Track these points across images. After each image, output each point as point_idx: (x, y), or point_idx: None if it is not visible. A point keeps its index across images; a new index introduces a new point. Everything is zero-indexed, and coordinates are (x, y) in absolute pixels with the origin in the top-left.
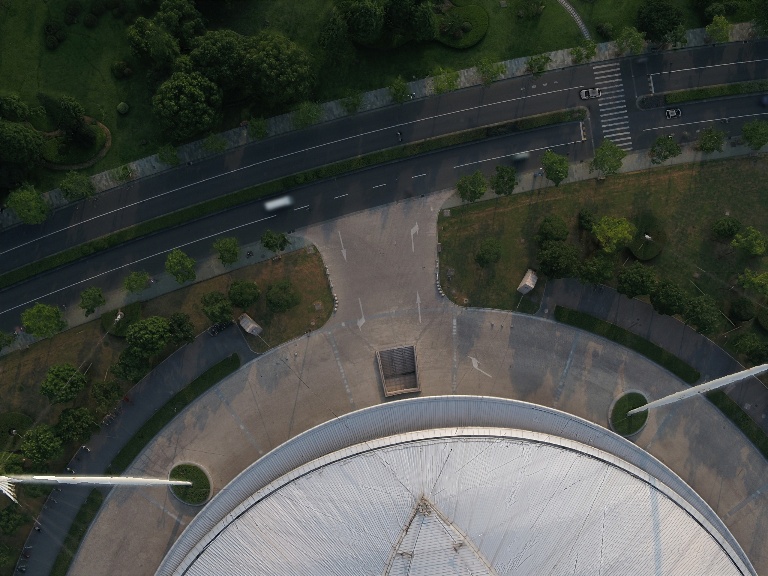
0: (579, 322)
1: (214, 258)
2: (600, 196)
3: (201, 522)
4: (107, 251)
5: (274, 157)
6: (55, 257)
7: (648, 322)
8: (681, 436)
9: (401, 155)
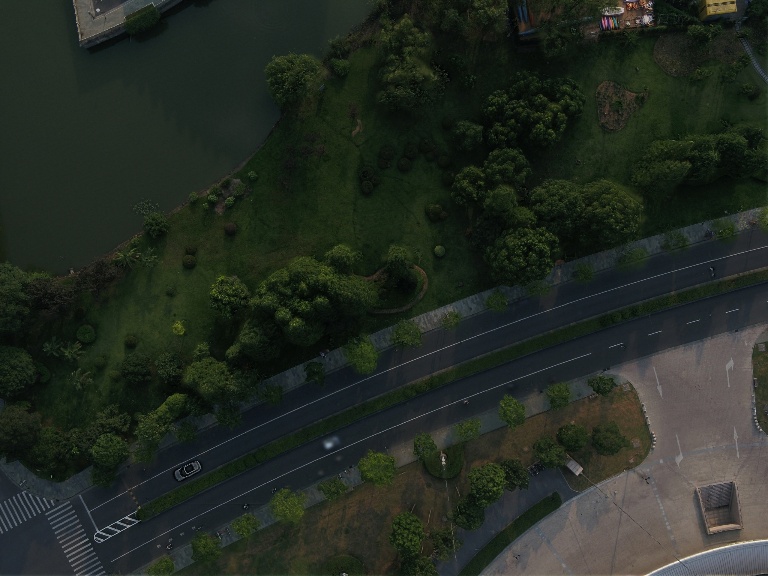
0: None
1: (531, 397)
2: None
3: None
4: (426, 393)
5: (588, 295)
6: (378, 401)
7: None
8: None
9: (716, 291)
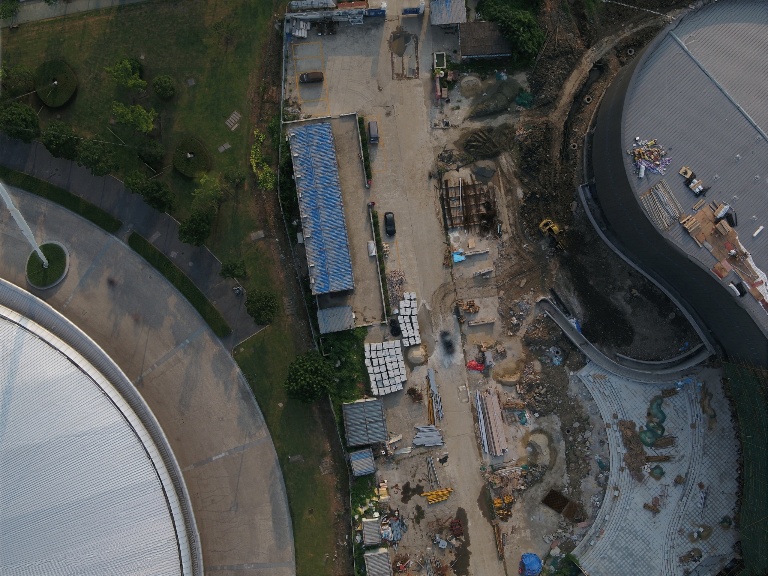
0: None
1: None
2: (13, 45)
3: None
4: None
5: None
6: None
7: (67, 172)
8: (105, 287)
9: None
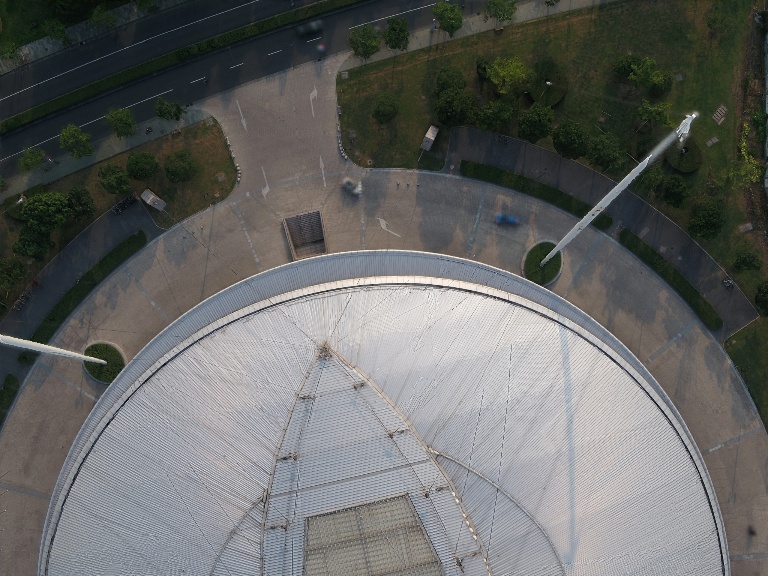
0: (485, 175)
1: (113, 136)
2: (499, 47)
3: (113, 393)
4: (6, 137)
5: (166, 31)
6: None
7: (556, 171)
8: (597, 284)
9: (294, 19)
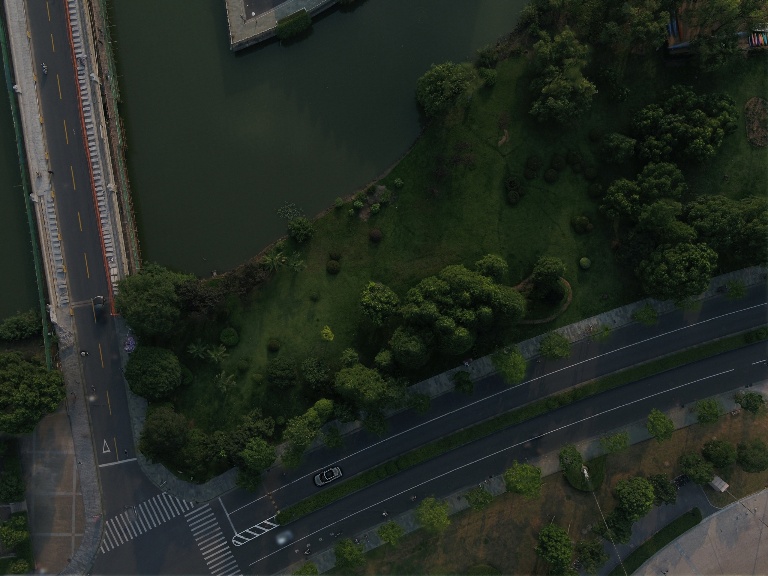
0: None
1: (673, 412)
2: None
3: None
4: (568, 404)
5: (732, 311)
6: (521, 411)
7: None
8: None
9: None
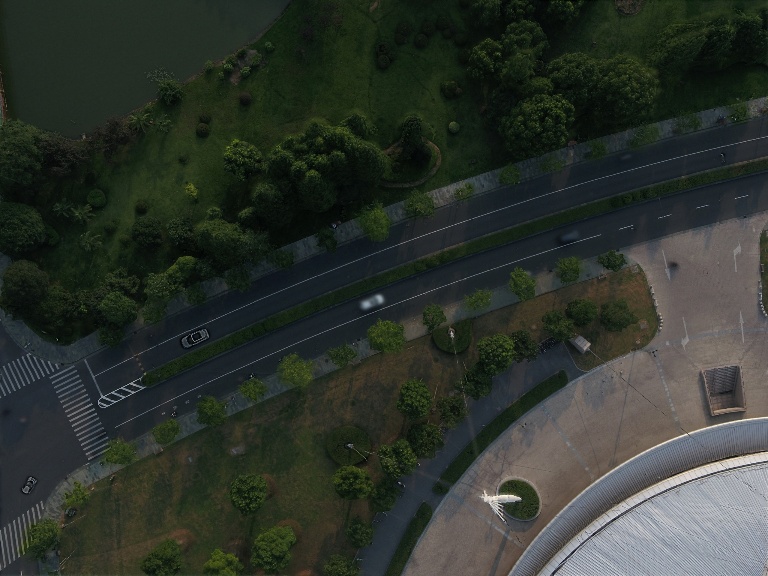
0: None
1: (541, 276)
2: None
3: (546, 538)
4: (437, 268)
5: (600, 177)
6: (389, 273)
7: None
8: None
9: (726, 176)
